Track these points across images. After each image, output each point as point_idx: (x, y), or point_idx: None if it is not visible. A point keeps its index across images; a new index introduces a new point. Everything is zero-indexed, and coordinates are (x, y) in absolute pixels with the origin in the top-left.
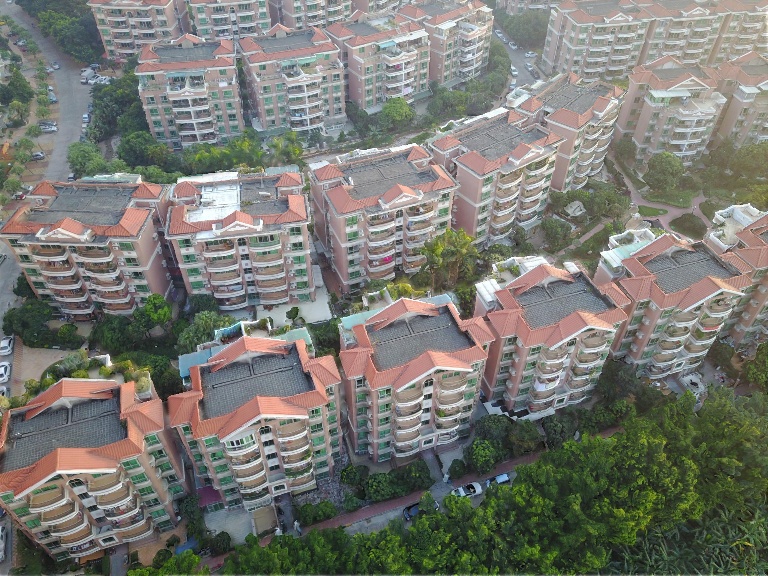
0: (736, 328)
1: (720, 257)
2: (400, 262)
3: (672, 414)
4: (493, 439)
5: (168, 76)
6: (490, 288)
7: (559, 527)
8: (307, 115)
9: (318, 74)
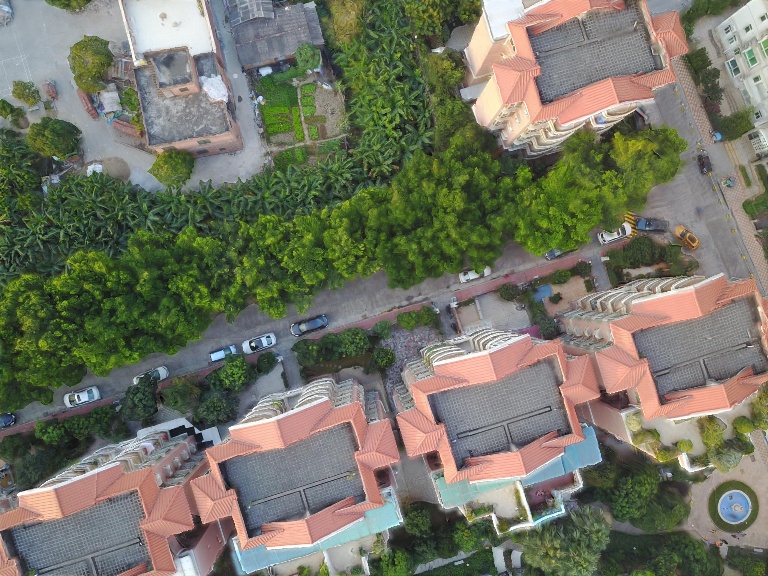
0: None
1: None
2: None
3: None
4: (219, 391)
5: None
6: None
7: None
8: None
9: None
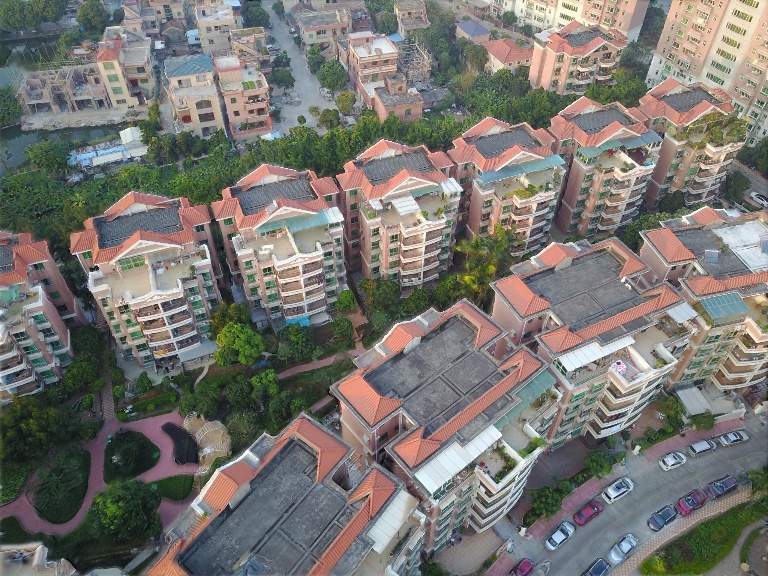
0: None
1: None
2: None
3: None
4: None
5: None
6: (451, 186)
7: None
8: None
9: None
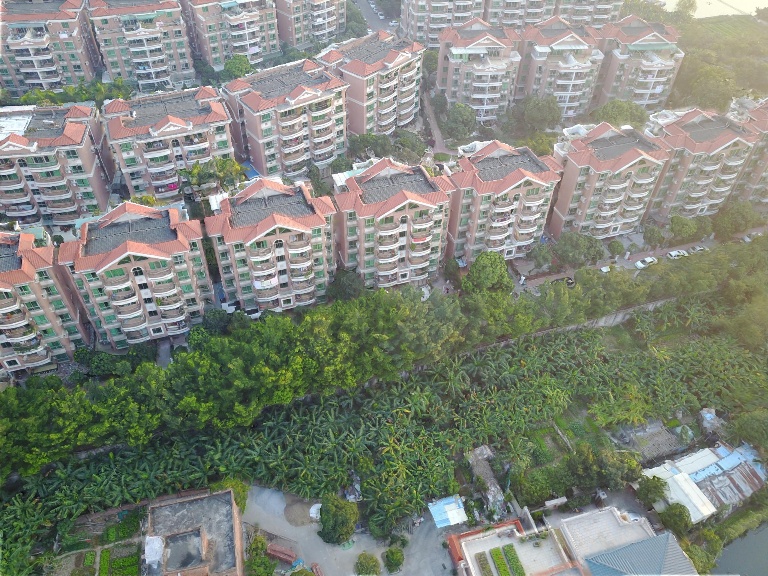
0: (465, 247)
1: (428, 178)
2: (190, 191)
3: (361, 306)
4: (213, 328)
5: (10, 27)
6: (219, 200)
7: (221, 385)
8: (151, 68)
9: (156, 29)
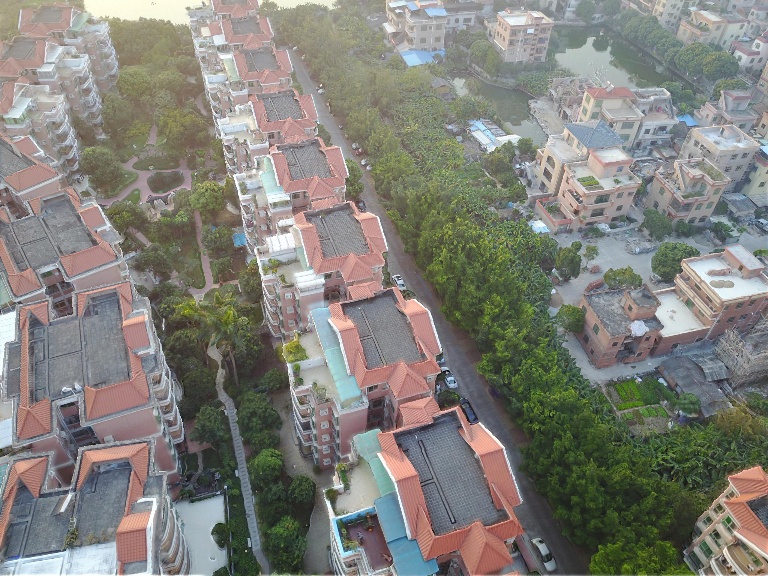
0: None
1: (297, 142)
2: None
3: None
4: None
5: None
6: (307, 278)
7: None
8: None
9: None
